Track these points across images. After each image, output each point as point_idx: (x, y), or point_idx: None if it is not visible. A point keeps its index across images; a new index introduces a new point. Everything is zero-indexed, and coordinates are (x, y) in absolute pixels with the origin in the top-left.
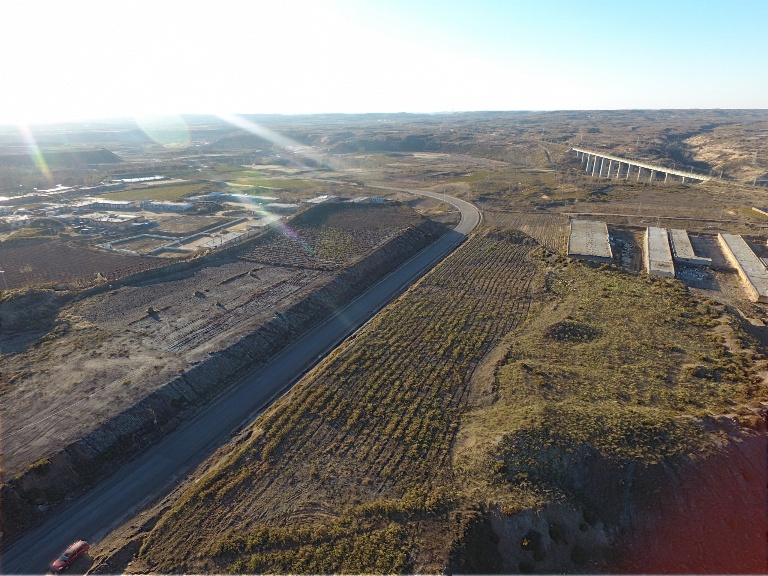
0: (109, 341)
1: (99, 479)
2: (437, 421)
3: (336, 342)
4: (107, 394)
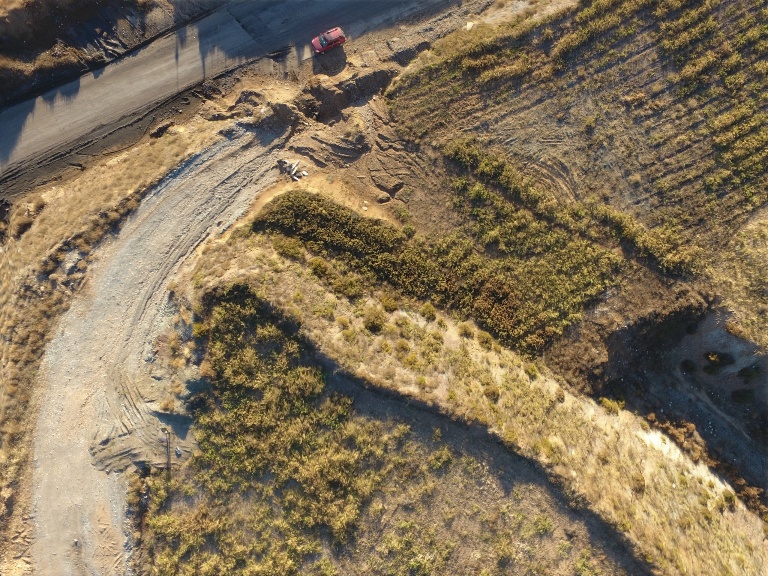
0: None
1: None
2: None
3: None
4: None
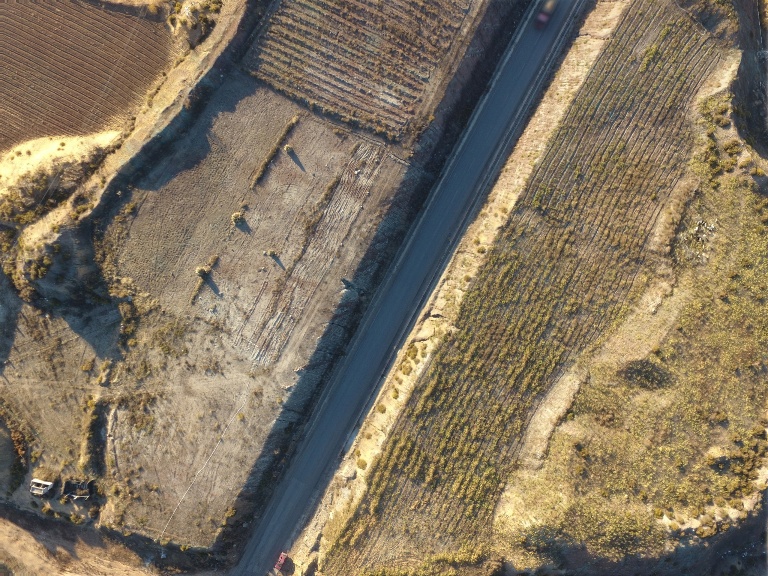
0: (190, 342)
1: (266, 501)
2: (491, 481)
3: (410, 318)
4: (234, 435)
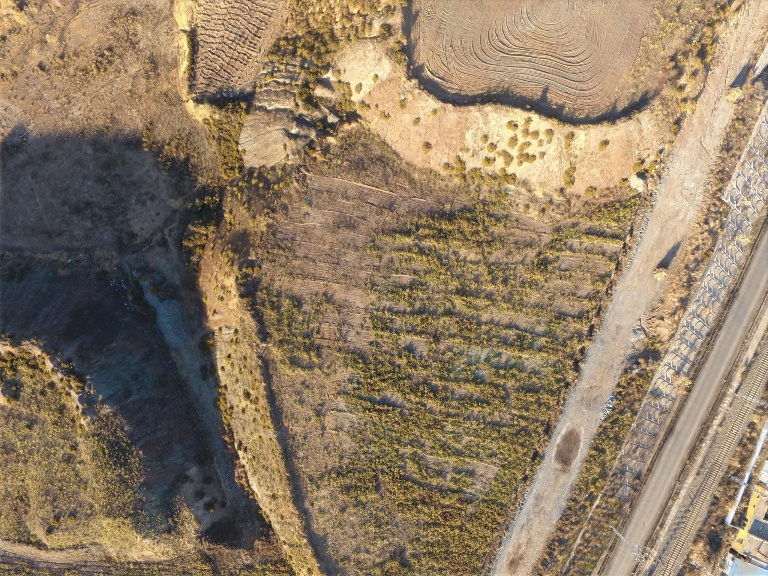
0: None
1: None
2: None
3: None
4: None
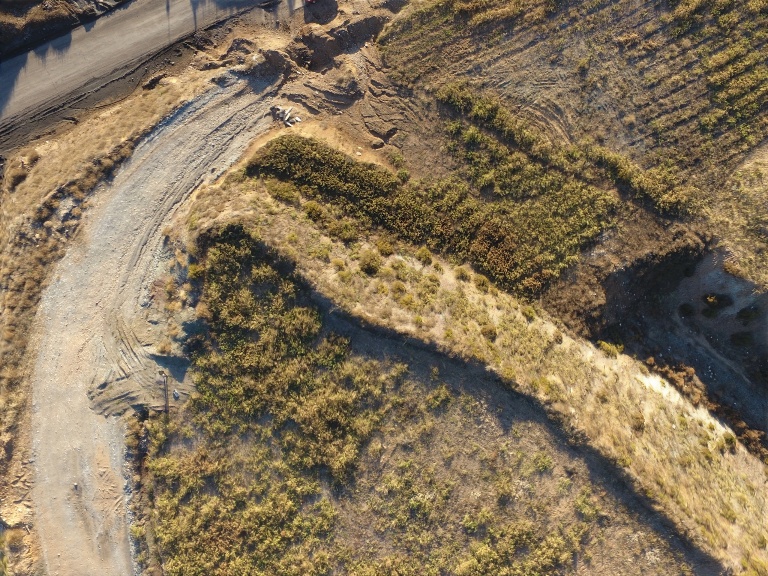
0: None
1: None
2: None
3: None
4: None
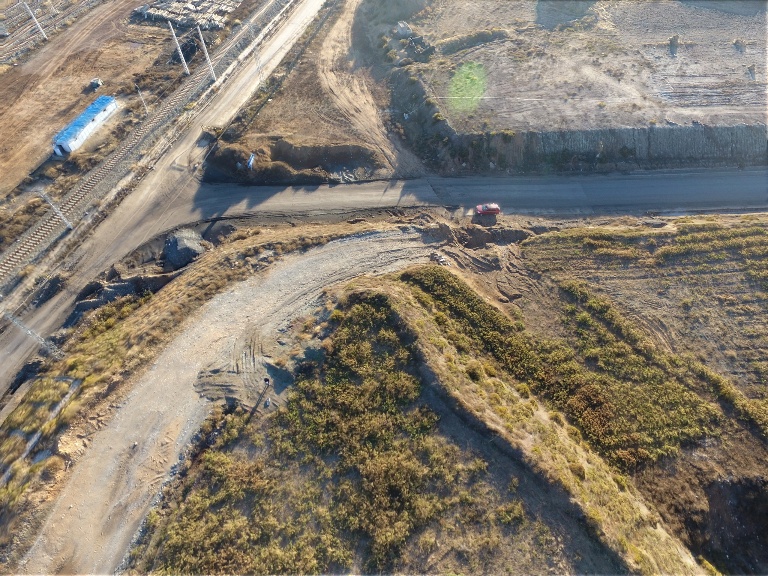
0: (616, 54)
1: (532, 172)
2: None
3: None
4: (581, 106)
